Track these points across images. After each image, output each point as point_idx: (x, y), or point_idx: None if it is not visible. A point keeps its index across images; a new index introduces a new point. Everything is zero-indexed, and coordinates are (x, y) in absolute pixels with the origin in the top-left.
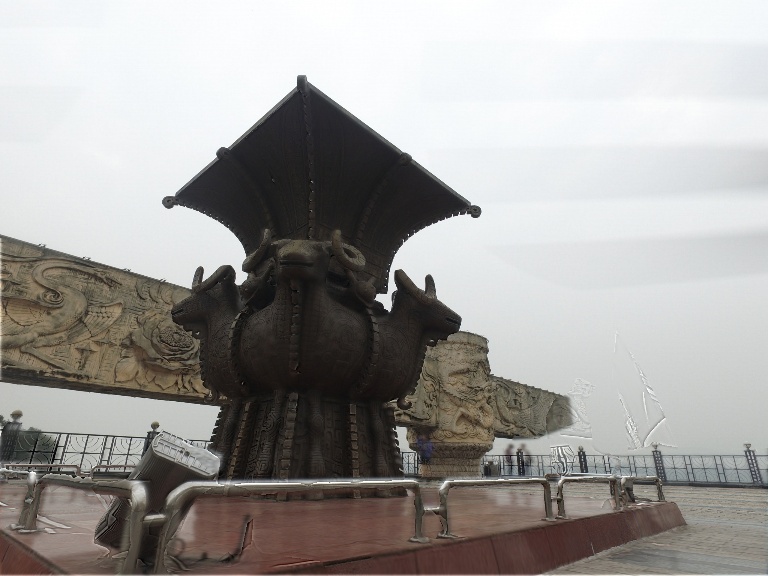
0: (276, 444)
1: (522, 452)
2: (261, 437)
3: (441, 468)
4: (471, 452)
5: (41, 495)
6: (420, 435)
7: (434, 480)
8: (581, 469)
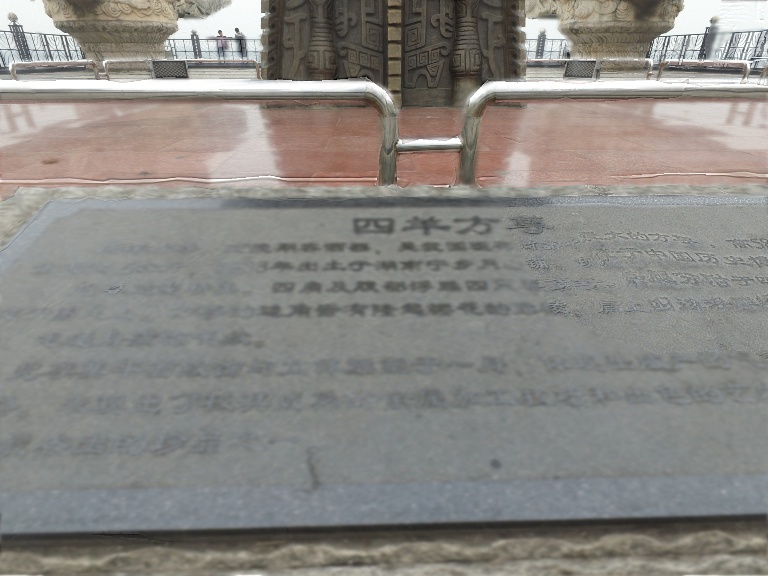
0: (478, 21)
1: (197, 35)
2: (429, 7)
3: (119, 56)
4: (156, 35)
5: (124, 151)
6: (78, 8)
7: (116, 72)
8: (758, 53)
